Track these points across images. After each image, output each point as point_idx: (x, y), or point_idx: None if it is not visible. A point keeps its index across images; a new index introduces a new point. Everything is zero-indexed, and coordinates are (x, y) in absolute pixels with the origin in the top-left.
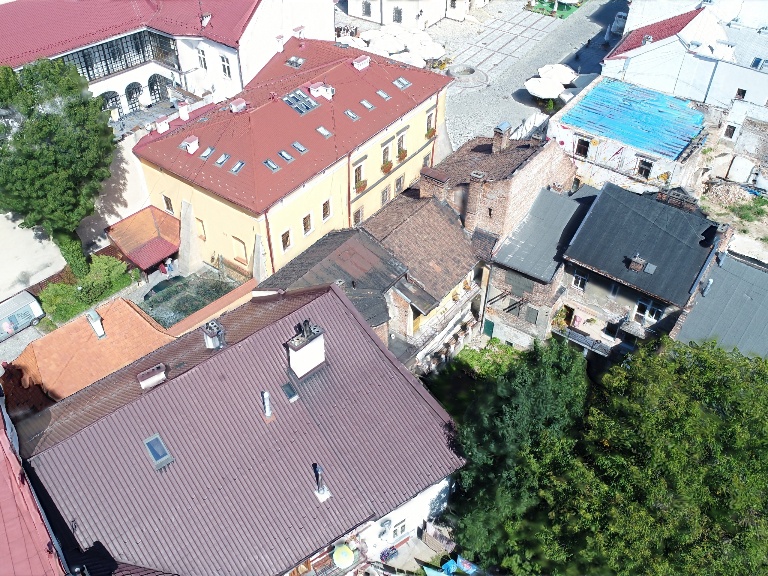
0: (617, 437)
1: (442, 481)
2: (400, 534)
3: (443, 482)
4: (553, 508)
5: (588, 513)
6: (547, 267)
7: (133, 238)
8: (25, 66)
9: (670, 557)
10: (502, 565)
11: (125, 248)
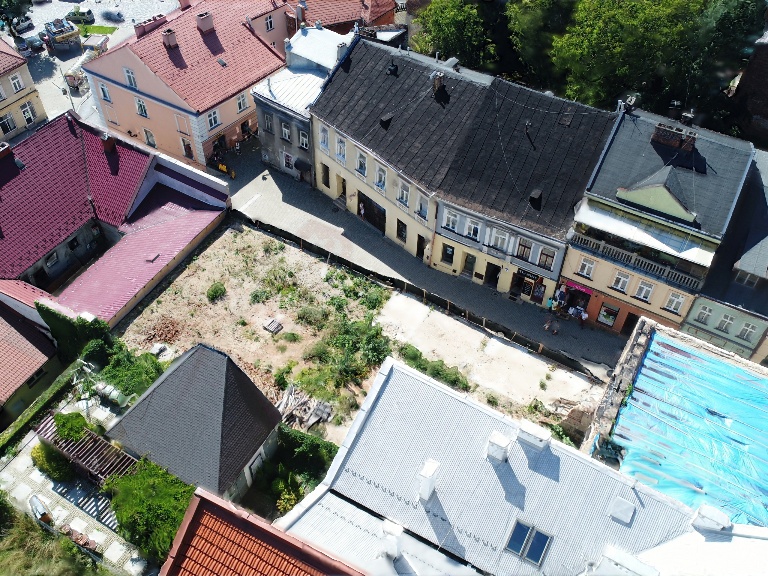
0: None
1: None
2: None
3: None
4: None
5: None
6: (758, 156)
7: None
8: None
9: None
10: None
11: None
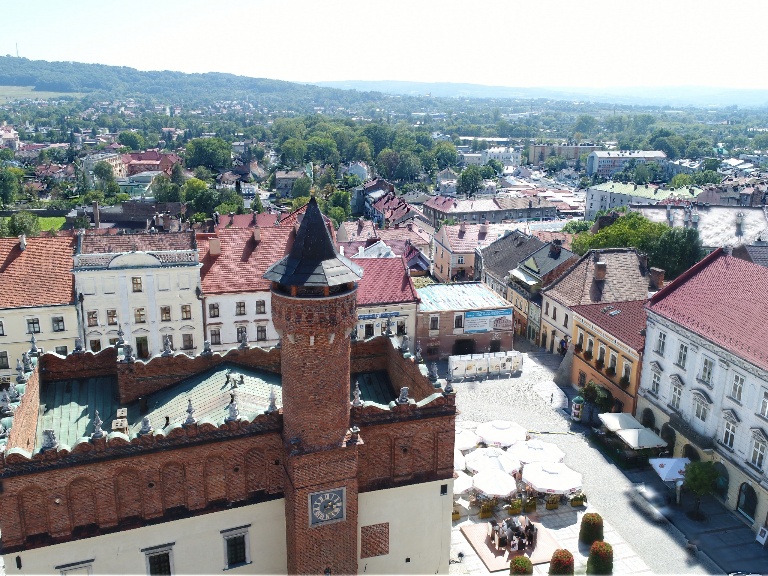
0: None
1: None
2: None
3: None
4: None
5: None
6: None
7: None
8: None
9: None
10: None
11: None
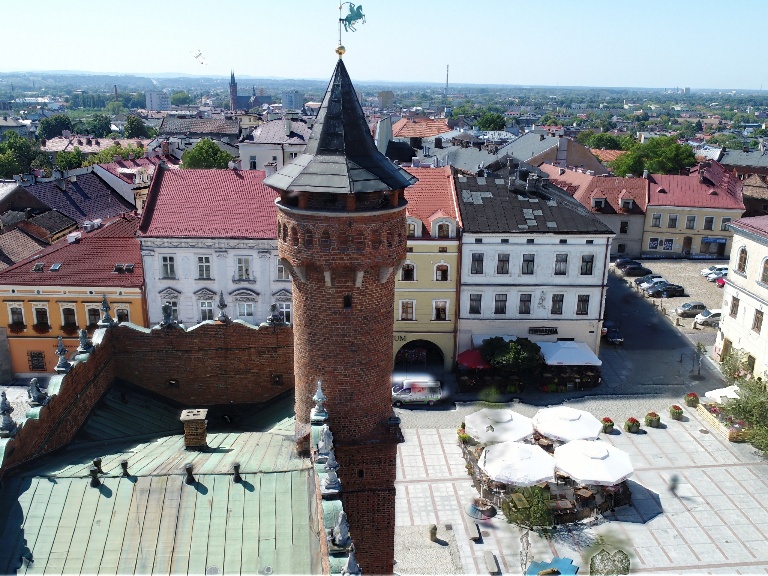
0: None
1: None
2: None
3: None
4: None
5: None
6: None
7: None
8: None
9: None
10: None
11: None
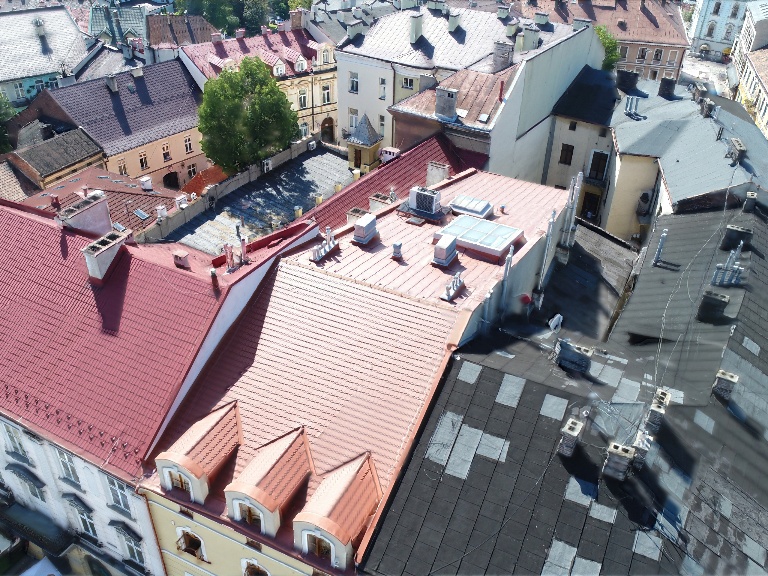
0: None
1: None
2: None
3: None
4: None
5: None
6: None
7: None
8: (242, 71)
9: None
10: None
11: None
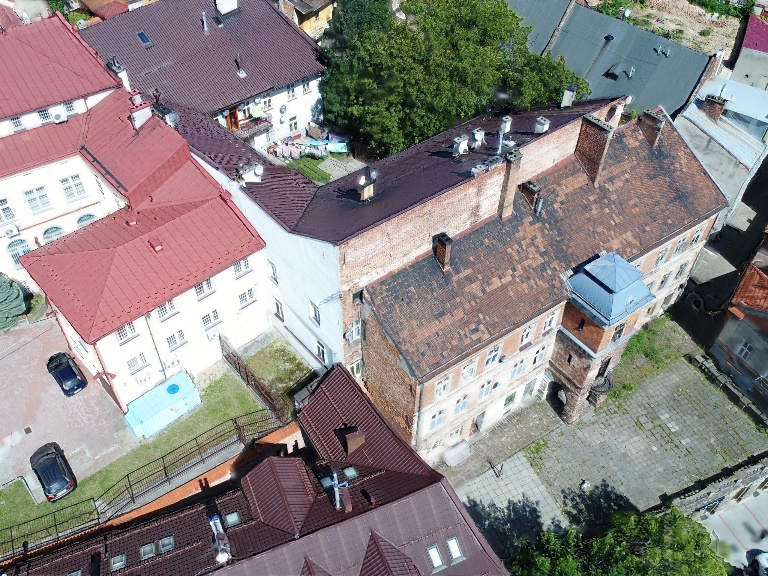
0: (404, 27)
1: (317, 92)
2: (295, 130)
3: (317, 93)
4: (369, 62)
5: (383, 51)
6: None
7: (97, 1)
8: None
9: (424, 65)
10: (348, 110)
11: (92, 7)
